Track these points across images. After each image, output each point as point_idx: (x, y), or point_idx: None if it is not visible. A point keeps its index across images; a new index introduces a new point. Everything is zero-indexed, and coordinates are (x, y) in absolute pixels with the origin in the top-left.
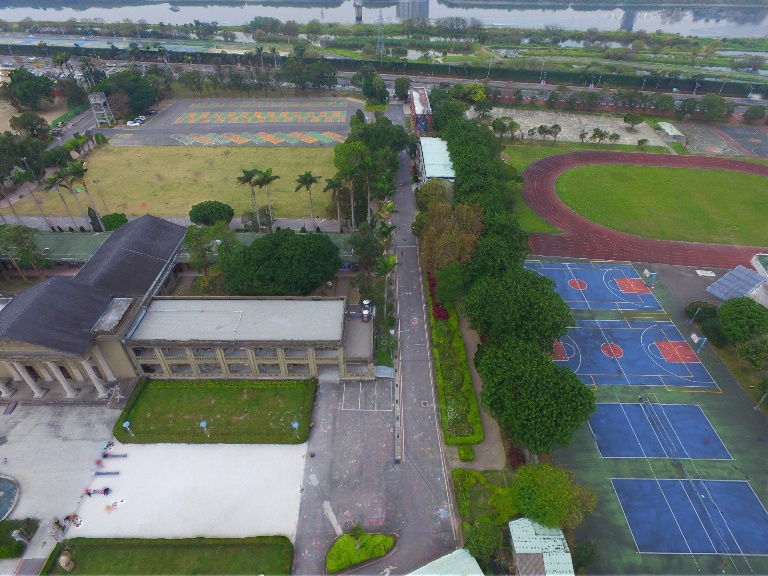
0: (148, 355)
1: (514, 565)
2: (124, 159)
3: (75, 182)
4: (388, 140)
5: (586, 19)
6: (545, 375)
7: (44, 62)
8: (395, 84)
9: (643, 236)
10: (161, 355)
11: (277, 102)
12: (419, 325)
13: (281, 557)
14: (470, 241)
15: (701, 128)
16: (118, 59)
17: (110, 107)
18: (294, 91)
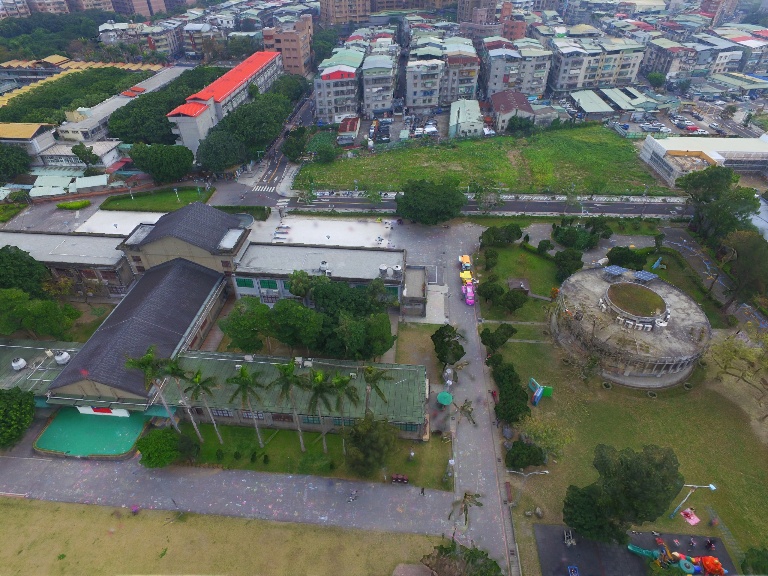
0: None
1: None
2: None
3: None
4: None
5: None
6: None
7: None
8: None
9: None
10: None
11: None
12: None
13: None
14: None
15: None
16: None
17: None
18: None
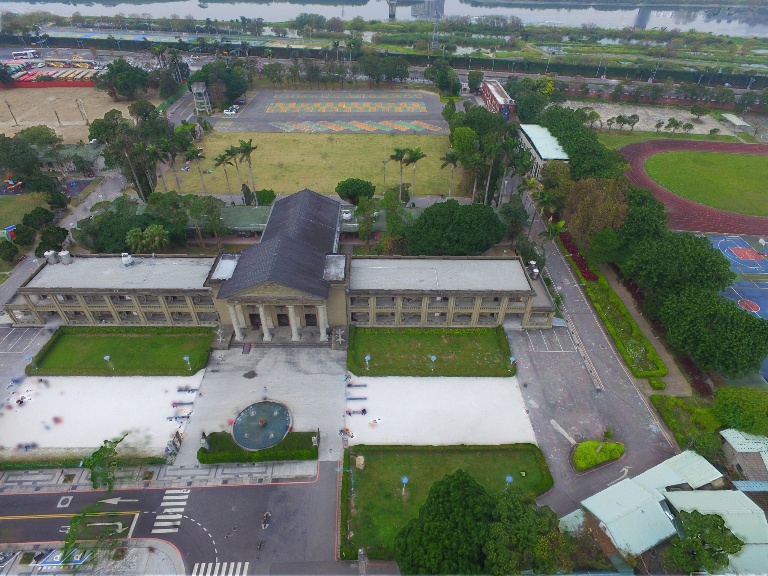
0: (359, 305)
1: (730, 464)
2: (237, 144)
3: (244, 159)
4: (491, 127)
5: (635, 17)
6: (736, 313)
7: (142, 53)
8: (469, 77)
9: (741, 213)
10: (374, 304)
11: (355, 94)
12: (572, 285)
13: (533, 460)
14: (624, 209)
15: (761, 120)
16: (202, 52)
17: (208, 96)
18: (367, 83)
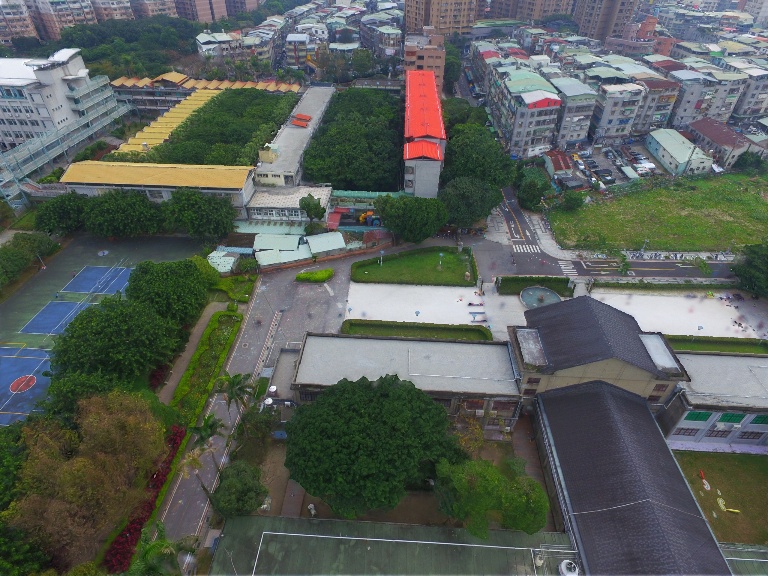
0: None
1: None
2: None
3: None
4: None
5: None
6: (159, 269)
7: None
8: None
9: None
10: None
11: None
12: None
13: None
14: None
15: None
16: None
17: None
18: None
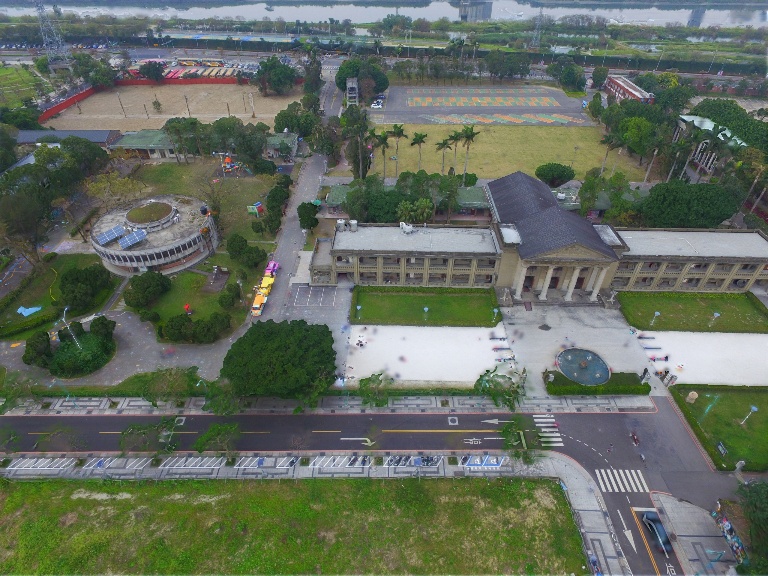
0: None
1: None
2: None
3: (466, 143)
4: (652, 117)
5: (741, 15)
6: None
7: (293, 51)
8: (595, 73)
9: None
10: (639, 269)
11: (481, 89)
12: None
13: None
14: None
15: None
16: (336, 50)
17: (358, 91)
18: (489, 80)
